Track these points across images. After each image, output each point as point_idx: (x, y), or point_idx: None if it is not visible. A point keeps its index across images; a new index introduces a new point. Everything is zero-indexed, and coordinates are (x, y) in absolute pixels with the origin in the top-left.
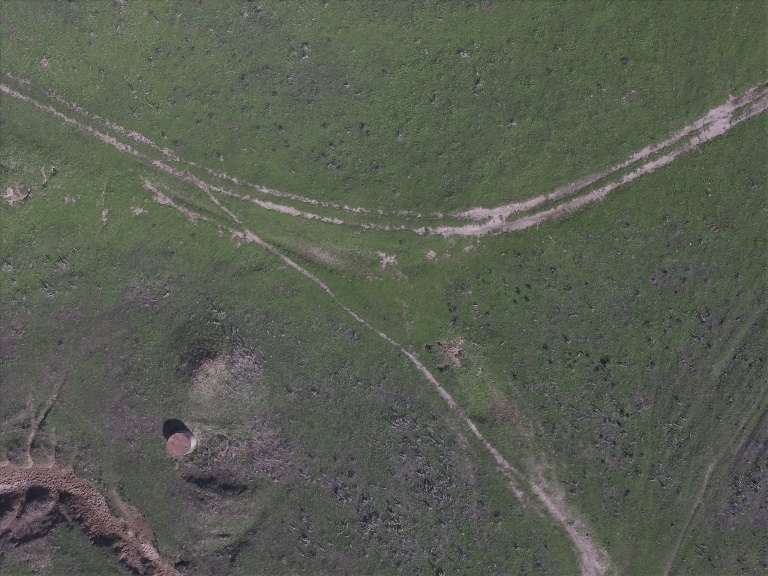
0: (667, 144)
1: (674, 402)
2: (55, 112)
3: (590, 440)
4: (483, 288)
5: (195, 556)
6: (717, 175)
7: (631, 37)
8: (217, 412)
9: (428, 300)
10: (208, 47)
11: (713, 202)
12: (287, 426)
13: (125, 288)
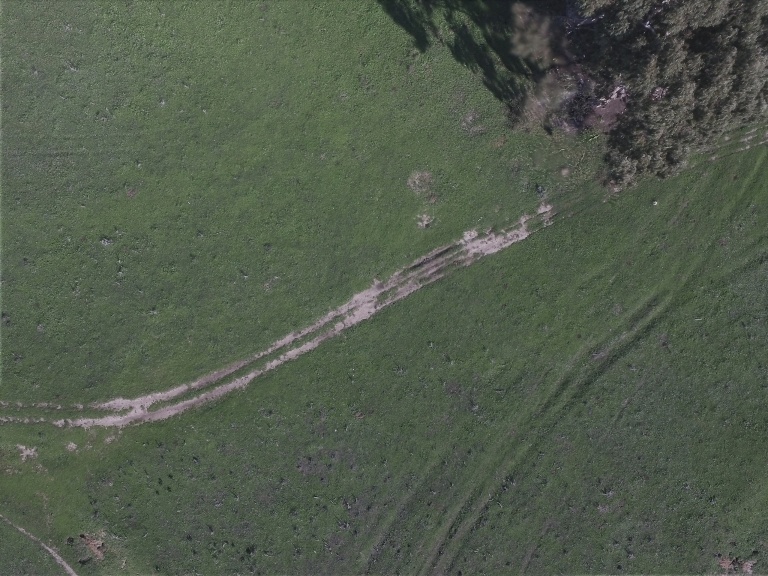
0: (311, 330)
1: None
2: None
3: None
4: (125, 480)
5: None
6: (362, 360)
7: (274, 223)
8: None
9: (69, 493)
10: None
11: (358, 388)
12: None
13: None
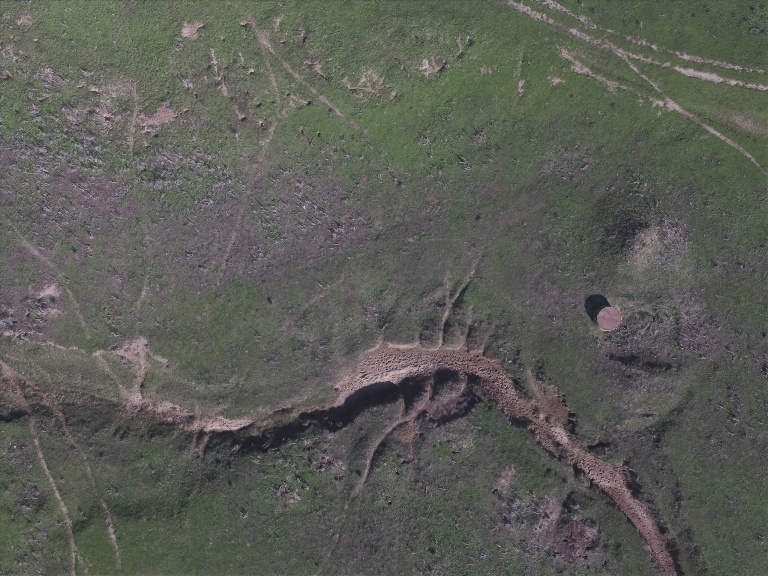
0: None
1: None
2: None
3: None
4: None
5: (615, 437)
6: None
7: None
8: (646, 285)
9: None
10: None
11: None
12: (712, 301)
13: (542, 161)
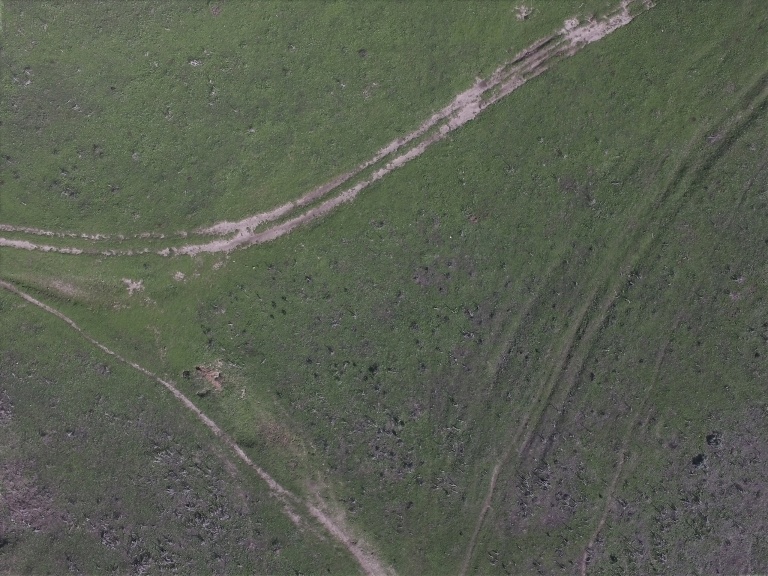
0: (416, 135)
1: (450, 404)
2: None
3: (366, 453)
4: (237, 305)
5: None
6: (471, 162)
7: (367, 28)
8: None
9: (180, 324)
10: None
11: (470, 191)
12: (44, 472)
13: None
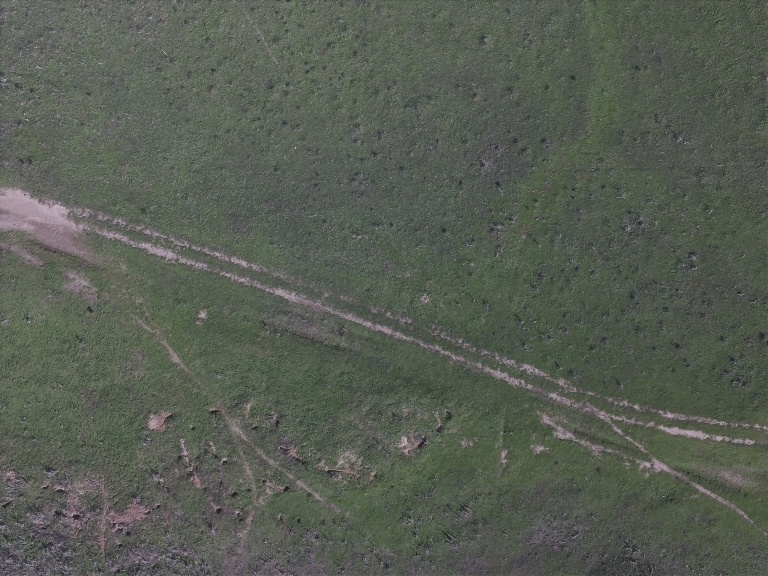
0: None
1: None
2: (441, 351)
3: None
4: None
5: None
6: None
7: None
8: None
9: None
10: (592, 267)
11: None
12: None
13: (531, 532)
